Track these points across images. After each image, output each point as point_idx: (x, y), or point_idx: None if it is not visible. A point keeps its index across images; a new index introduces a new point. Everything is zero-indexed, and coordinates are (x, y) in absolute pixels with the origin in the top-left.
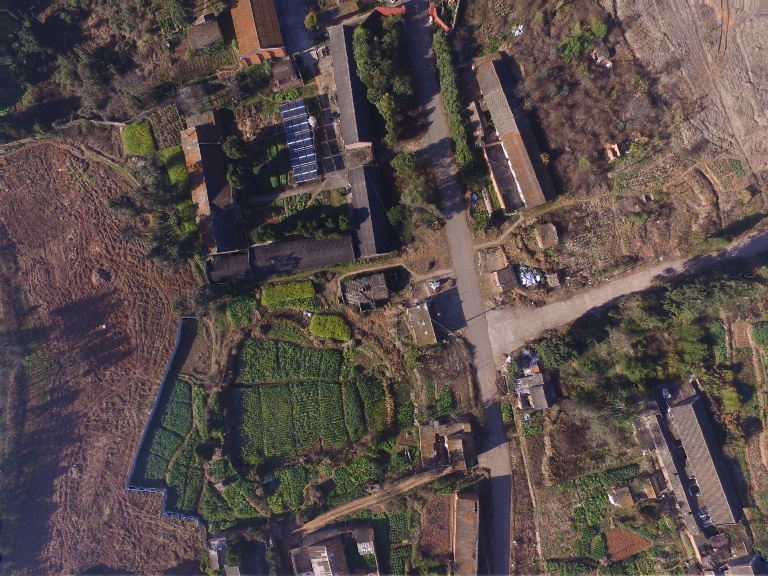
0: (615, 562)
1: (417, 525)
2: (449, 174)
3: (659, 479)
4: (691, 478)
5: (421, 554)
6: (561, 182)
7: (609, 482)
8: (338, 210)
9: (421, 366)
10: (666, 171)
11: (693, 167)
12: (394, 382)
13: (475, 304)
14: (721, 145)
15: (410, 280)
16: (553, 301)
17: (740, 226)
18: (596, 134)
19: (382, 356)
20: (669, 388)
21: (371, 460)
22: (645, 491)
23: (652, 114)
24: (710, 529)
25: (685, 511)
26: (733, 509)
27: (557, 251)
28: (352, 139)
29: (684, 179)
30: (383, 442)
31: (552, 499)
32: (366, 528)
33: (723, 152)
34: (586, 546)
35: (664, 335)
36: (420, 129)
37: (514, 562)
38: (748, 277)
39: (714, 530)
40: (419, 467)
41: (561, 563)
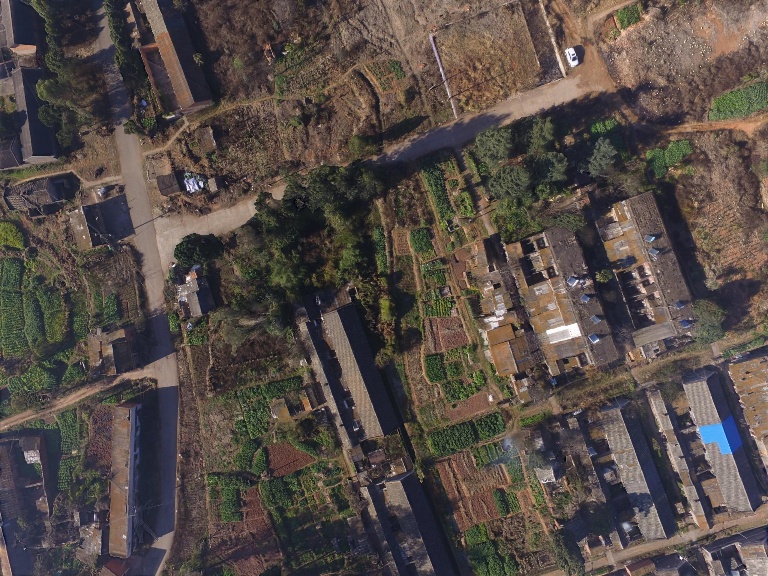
0: (277, 477)
1: (86, 436)
2: (119, 80)
3: (315, 390)
4: (347, 390)
5: (83, 463)
6: (219, 84)
7: (269, 394)
8: (11, 116)
9: (88, 273)
10: (326, 73)
11: (352, 68)
12: (70, 292)
13: (143, 211)
14: (381, 46)
15: (80, 187)
16: (218, 208)
17: (398, 129)
18: (255, 36)
19: (58, 265)
20: (324, 296)
21: (45, 369)
22: (303, 403)
23: (311, 14)
24: (373, 445)
25: (338, 423)
26: (383, 421)
27: (220, 156)
28: (10, 41)
29: (344, 81)
30: (60, 352)
31: (214, 411)
32: (34, 437)
33: (382, 53)
34: (246, 460)
35: (326, 243)
36: (88, 34)
37: (179, 475)
38: (406, 181)
39: (375, 446)
40: (91, 377)
41: (221, 476)
